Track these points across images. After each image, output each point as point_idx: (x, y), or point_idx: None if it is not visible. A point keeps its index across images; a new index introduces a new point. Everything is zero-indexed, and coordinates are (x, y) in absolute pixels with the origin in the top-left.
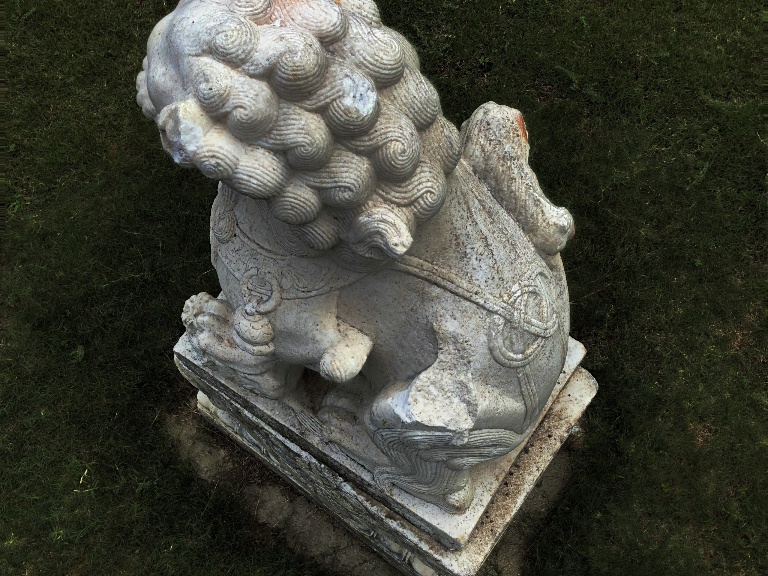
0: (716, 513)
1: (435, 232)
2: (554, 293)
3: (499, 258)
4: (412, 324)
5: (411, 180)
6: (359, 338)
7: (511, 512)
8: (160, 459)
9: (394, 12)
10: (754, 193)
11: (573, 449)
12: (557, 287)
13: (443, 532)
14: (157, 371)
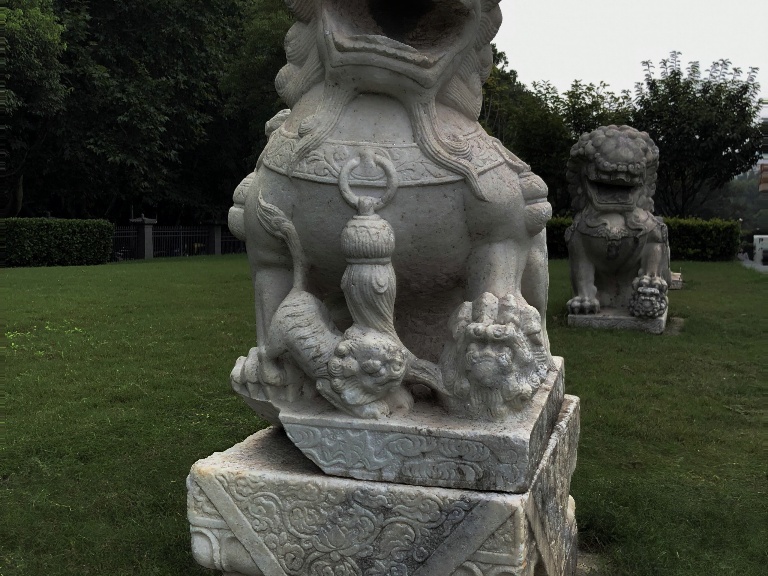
0: None
1: None
2: None
3: None
4: None
5: None
6: None
7: None
8: None
9: None
10: None
11: None
12: None
13: None
14: None
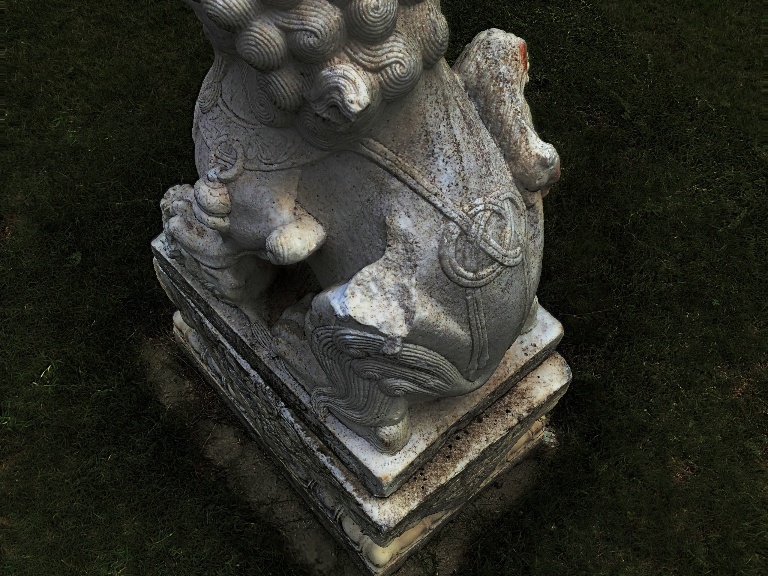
0: (680, 554)
1: (405, 122)
2: (524, 227)
3: (468, 167)
4: (366, 216)
5: (382, 45)
6: (312, 225)
7: (448, 475)
8: (124, 373)
9: (463, 19)
10: None
11: (543, 458)
12: (531, 229)
13: (368, 469)
14: (145, 291)
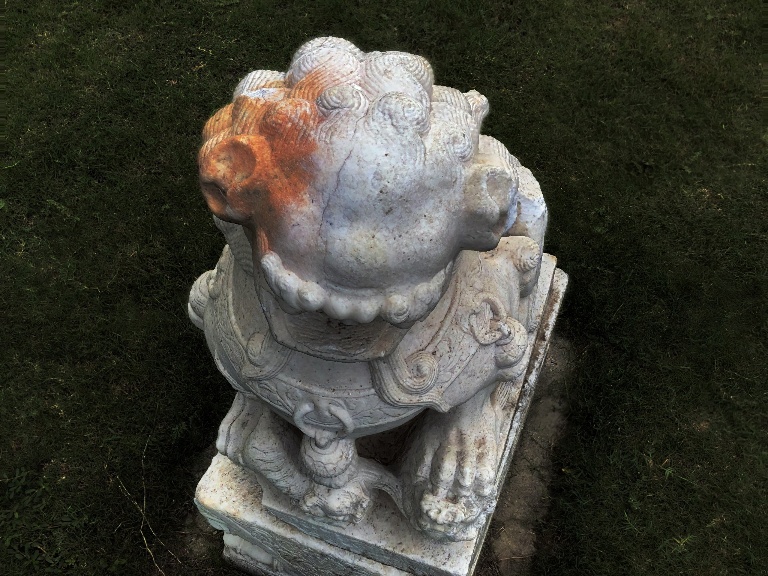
0: None
1: None
2: None
3: None
4: None
5: None
6: None
7: None
8: None
9: None
10: (78, 172)
11: None
12: None
13: None
14: None
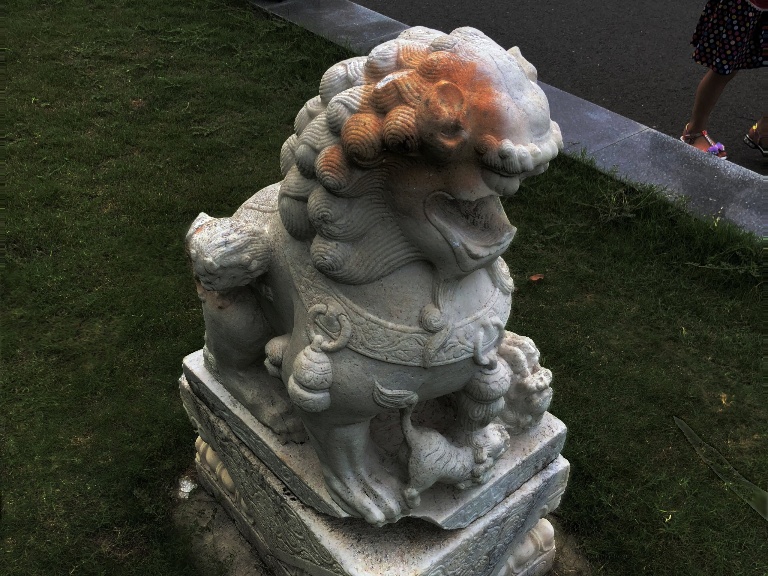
0: None
1: None
2: None
3: None
4: None
5: None
6: None
7: None
8: None
9: None
10: None
11: None
12: None
13: None
14: None
